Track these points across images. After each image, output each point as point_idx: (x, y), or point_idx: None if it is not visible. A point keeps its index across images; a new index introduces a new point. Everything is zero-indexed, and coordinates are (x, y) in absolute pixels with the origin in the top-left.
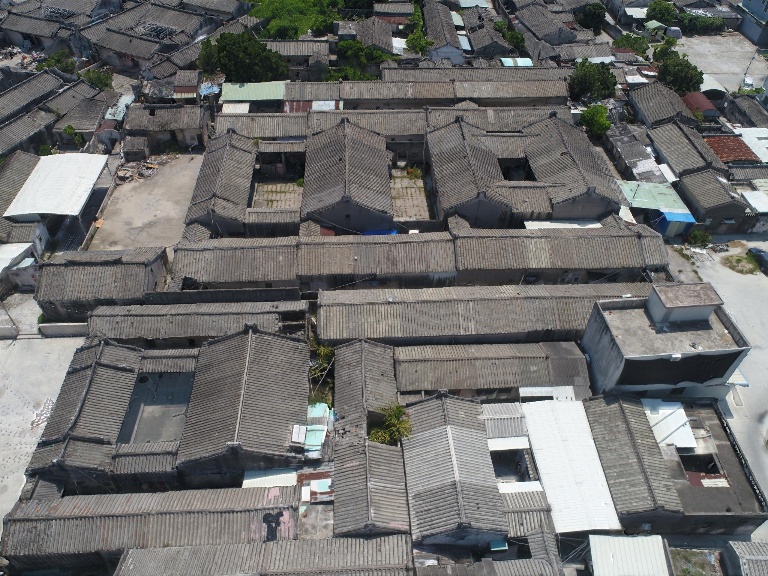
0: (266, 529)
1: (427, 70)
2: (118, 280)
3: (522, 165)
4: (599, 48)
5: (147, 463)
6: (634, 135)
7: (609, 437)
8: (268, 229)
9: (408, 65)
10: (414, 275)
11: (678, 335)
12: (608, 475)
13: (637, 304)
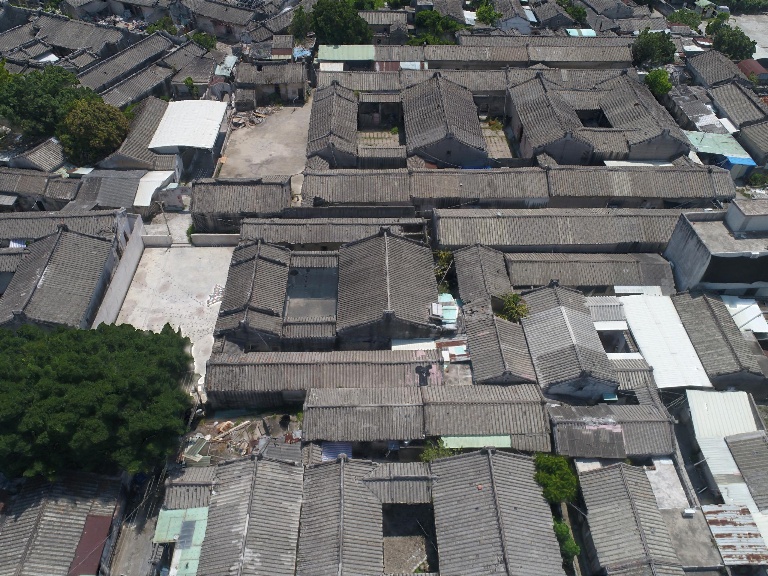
0: (418, 378)
1: (500, 37)
2: (259, 197)
3: (595, 118)
4: (656, 22)
5: (311, 330)
6: (695, 95)
7: (696, 321)
8: (377, 163)
9: (480, 34)
10: (512, 201)
11: (754, 241)
12: (698, 349)
13: (717, 217)
